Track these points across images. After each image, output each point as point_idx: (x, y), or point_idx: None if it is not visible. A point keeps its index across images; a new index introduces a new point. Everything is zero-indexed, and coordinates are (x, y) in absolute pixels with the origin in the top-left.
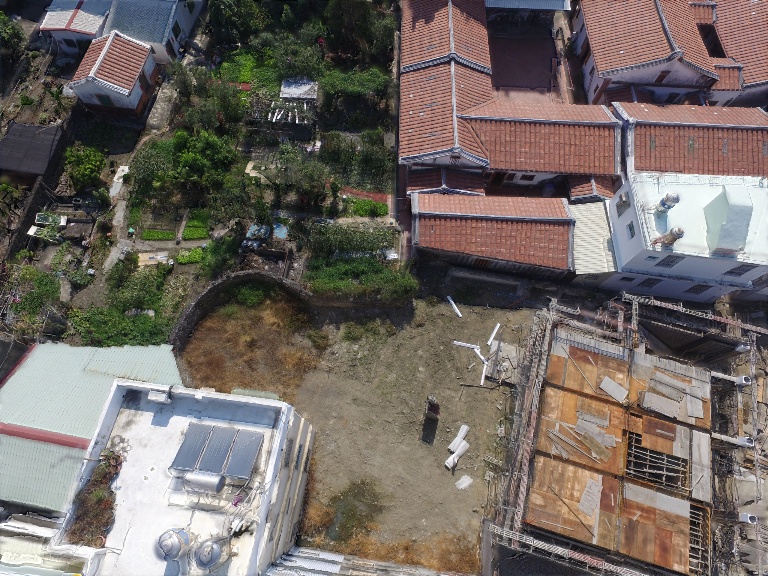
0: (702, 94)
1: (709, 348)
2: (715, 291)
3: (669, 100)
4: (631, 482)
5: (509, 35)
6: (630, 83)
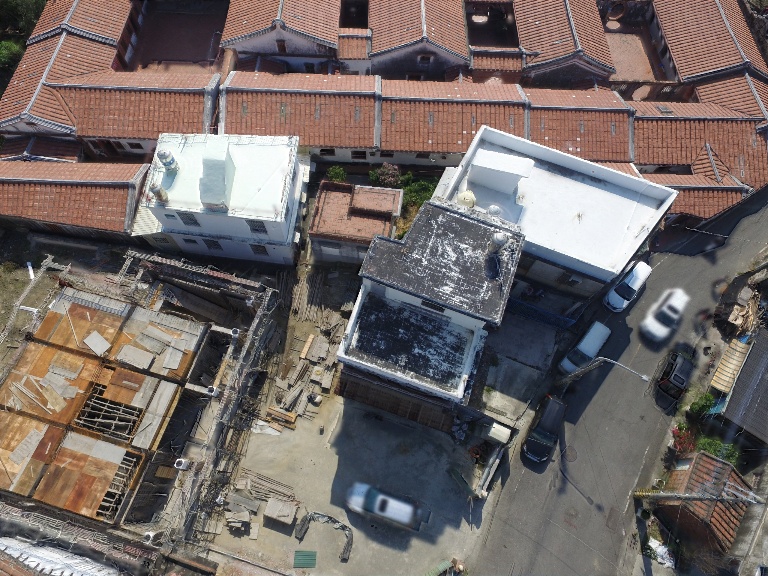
0: (333, 64)
1: (239, 305)
2: (274, 251)
3: (310, 71)
4: (80, 431)
5: (191, 11)
6: (257, 53)
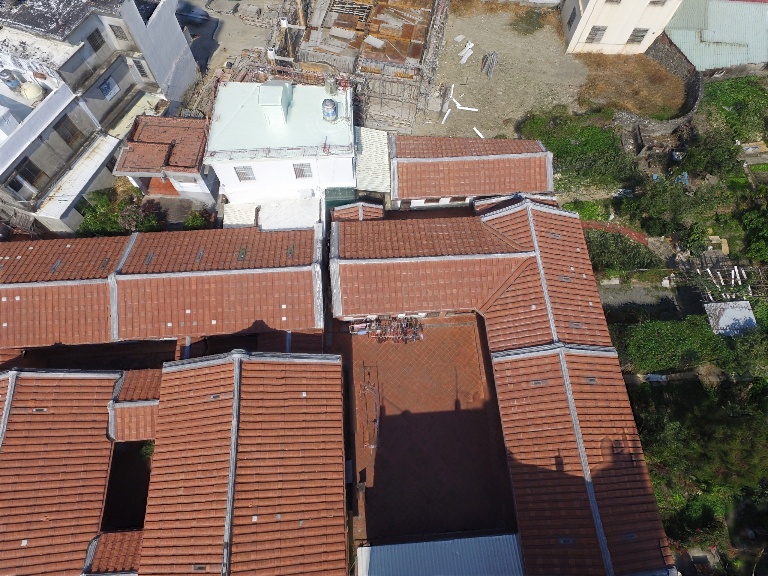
0: None
1: None
2: None
3: None
4: None
5: (446, 537)
6: None
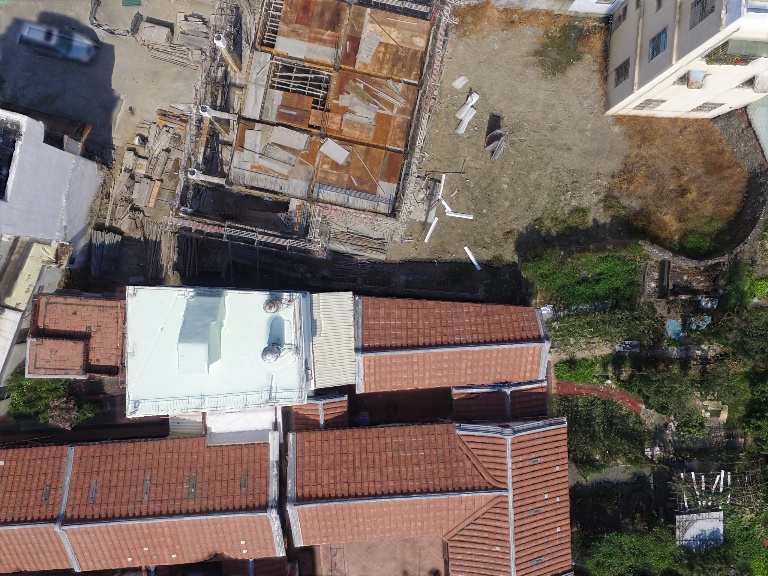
0: None
1: None
2: None
3: None
4: None
5: None
6: None
